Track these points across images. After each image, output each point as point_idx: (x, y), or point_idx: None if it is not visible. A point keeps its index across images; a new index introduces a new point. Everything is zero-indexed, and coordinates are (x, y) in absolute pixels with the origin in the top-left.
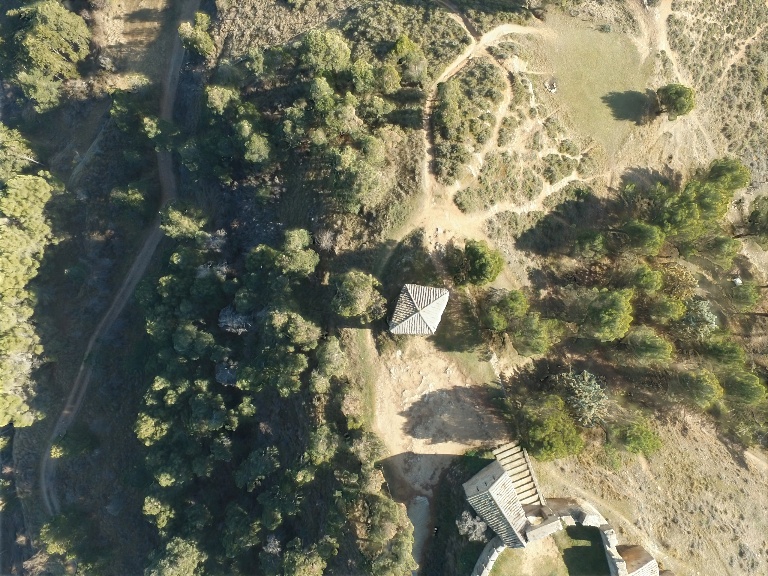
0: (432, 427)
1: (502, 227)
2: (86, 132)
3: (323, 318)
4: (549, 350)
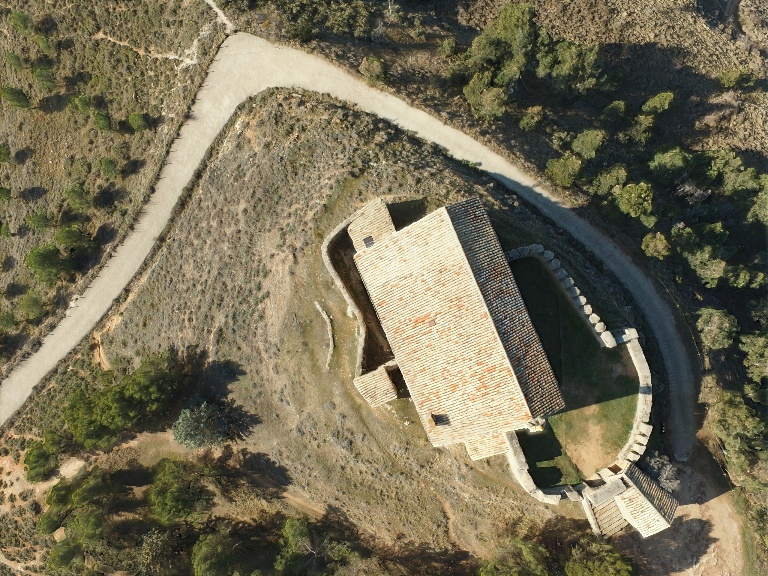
0: (685, 533)
1: None
2: None
3: None
4: None
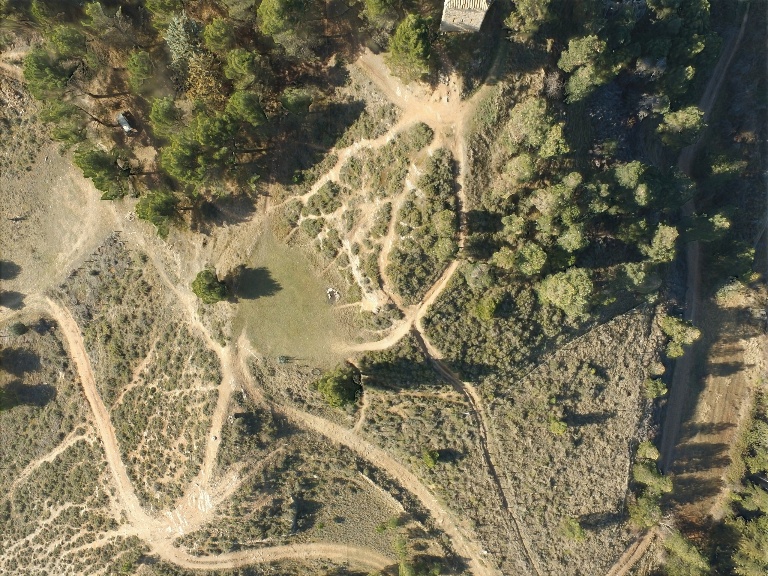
0: None
1: (380, 120)
2: (767, 250)
3: (551, 1)
4: (324, 0)
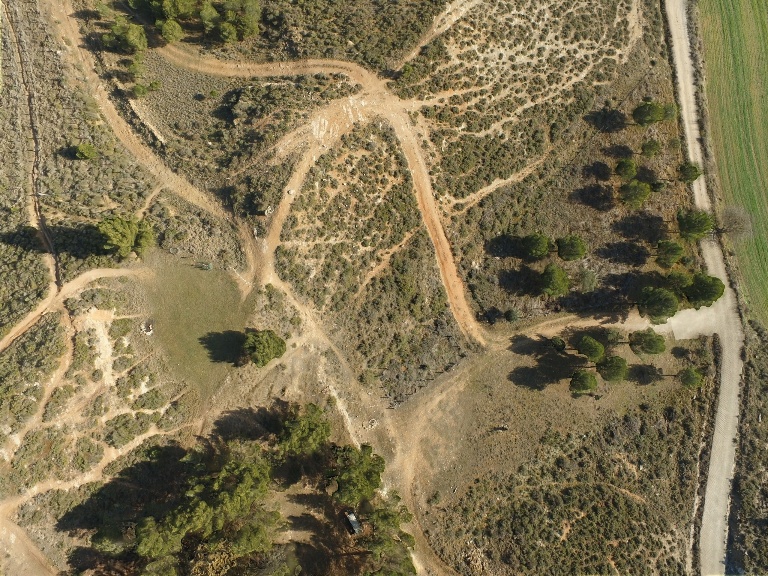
0: None
1: (41, 509)
2: None
3: None
4: None
